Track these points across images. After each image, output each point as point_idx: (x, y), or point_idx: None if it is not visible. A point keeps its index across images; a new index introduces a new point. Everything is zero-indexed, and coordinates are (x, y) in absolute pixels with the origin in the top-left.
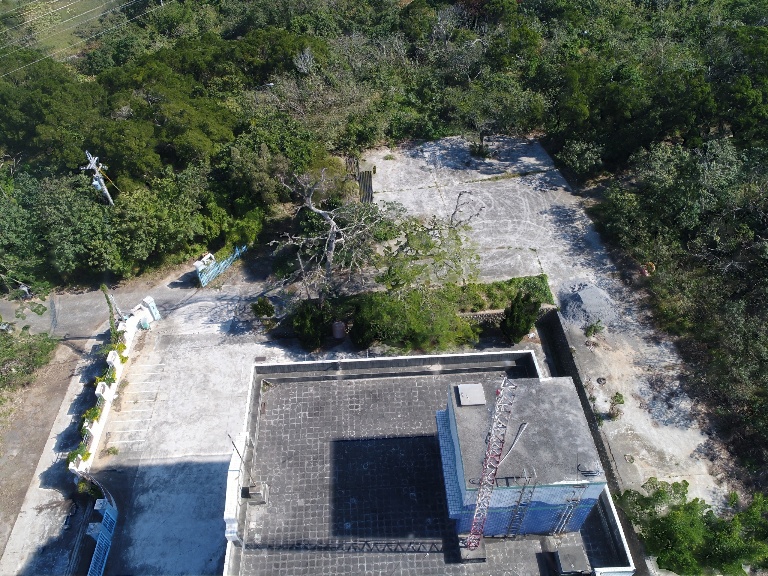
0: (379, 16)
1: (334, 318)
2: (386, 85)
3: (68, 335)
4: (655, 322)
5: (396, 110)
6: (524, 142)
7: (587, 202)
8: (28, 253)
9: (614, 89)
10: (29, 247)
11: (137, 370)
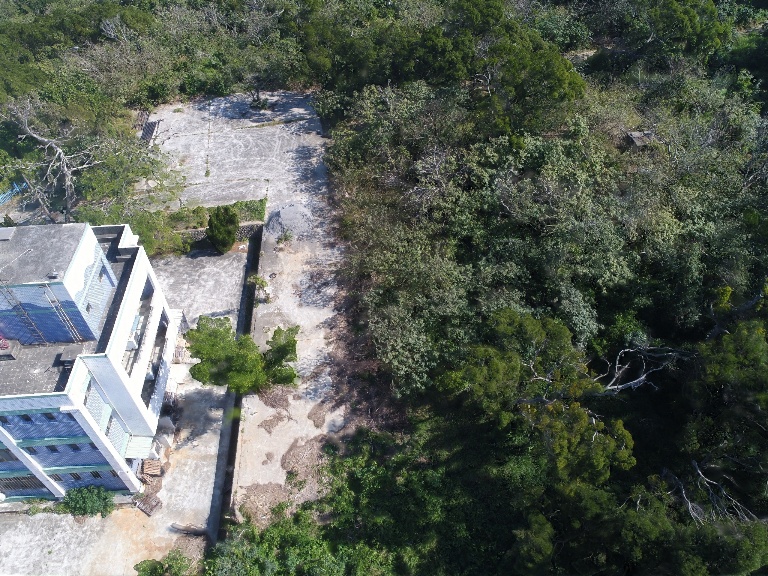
0: None
1: None
2: (191, 49)
3: None
4: (337, 231)
5: (199, 71)
6: (301, 96)
7: (330, 142)
8: None
9: (351, 43)
10: None
11: None
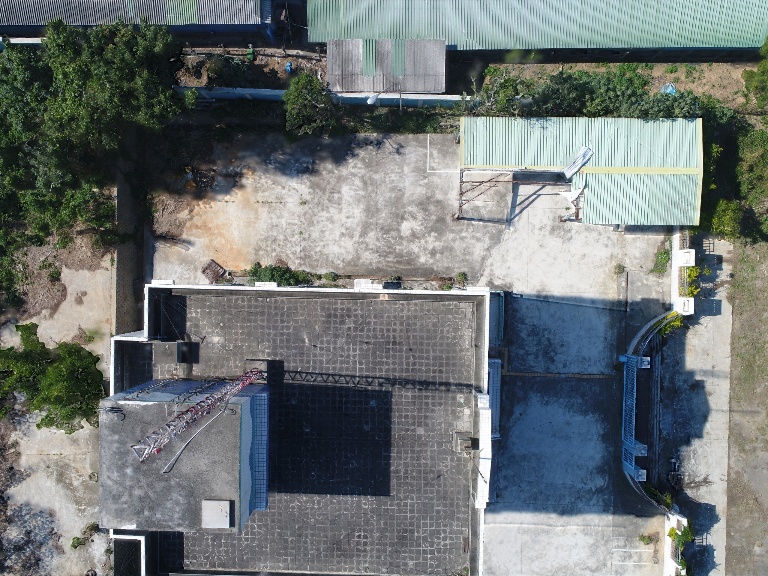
0: None
1: None
2: None
3: None
4: None
5: None
6: None
7: None
8: None
9: None
10: None
11: None
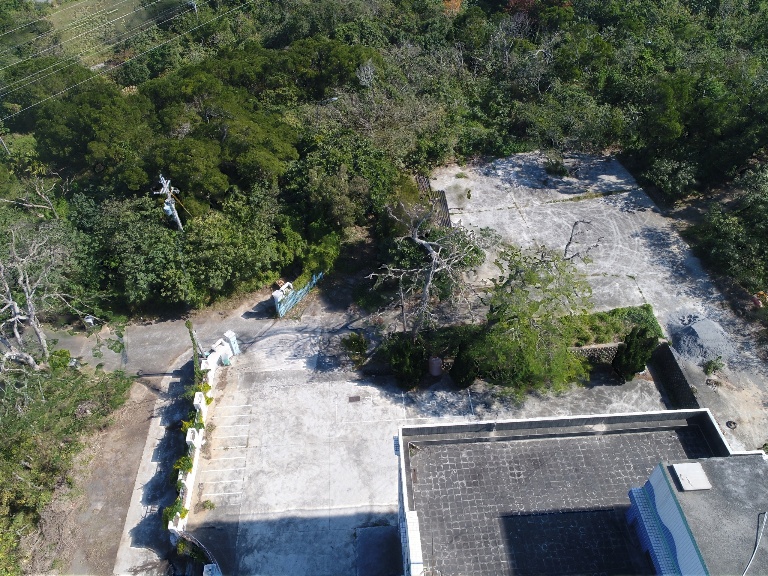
0: (425, 24)
1: (429, 353)
2: (450, 98)
3: (141, 371)
4: None
5: (461, 124)
6: (601, 159)
7: (679, 224)
8: (92, 282)
9: (708, 105)
10: (93, 275)
11: (223, 412)
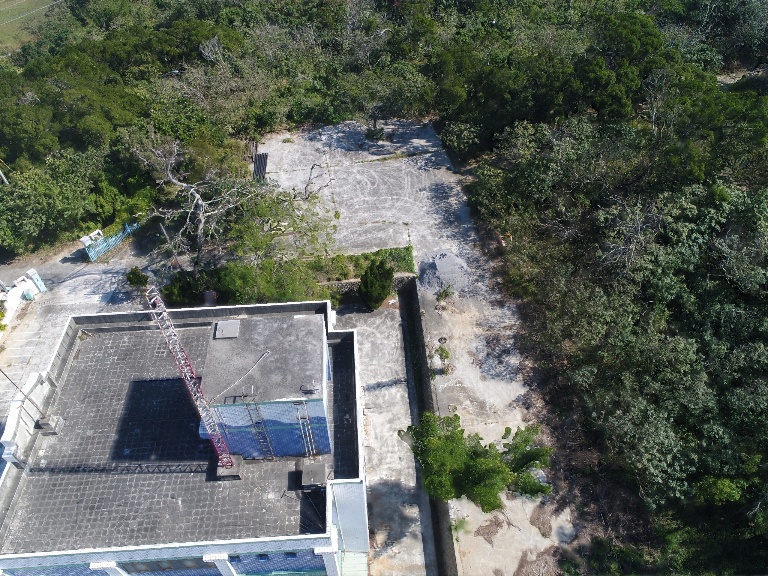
0: (307, 8)
1: (208, 288)
2: (292, 72)
3: None
4: (503, 287)
5: (302, 96)
6: (418, 125)
7: (465, 180)
8: None
9: (489, 72)
10: None
11: (15, 337)
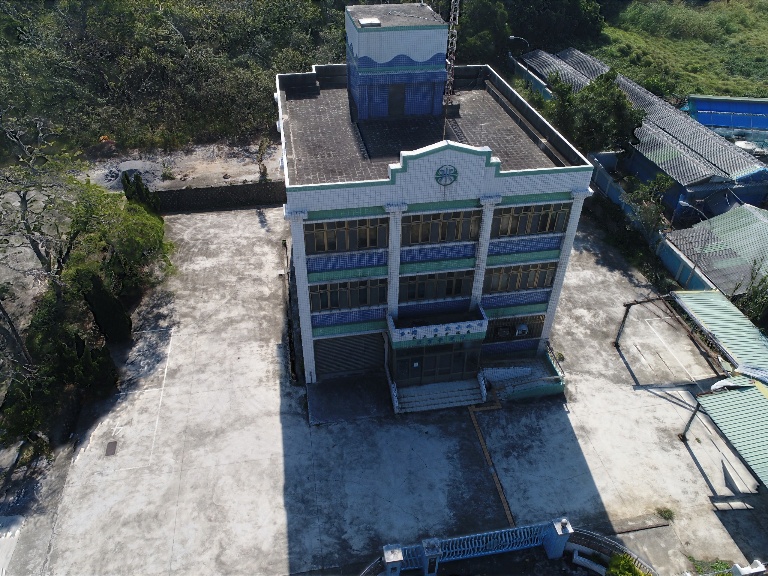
0: None
1: None
2: None
3: None
4: (171, 148)
5: None
6: None
7: None
8: None
9: None
10: None
11: None
